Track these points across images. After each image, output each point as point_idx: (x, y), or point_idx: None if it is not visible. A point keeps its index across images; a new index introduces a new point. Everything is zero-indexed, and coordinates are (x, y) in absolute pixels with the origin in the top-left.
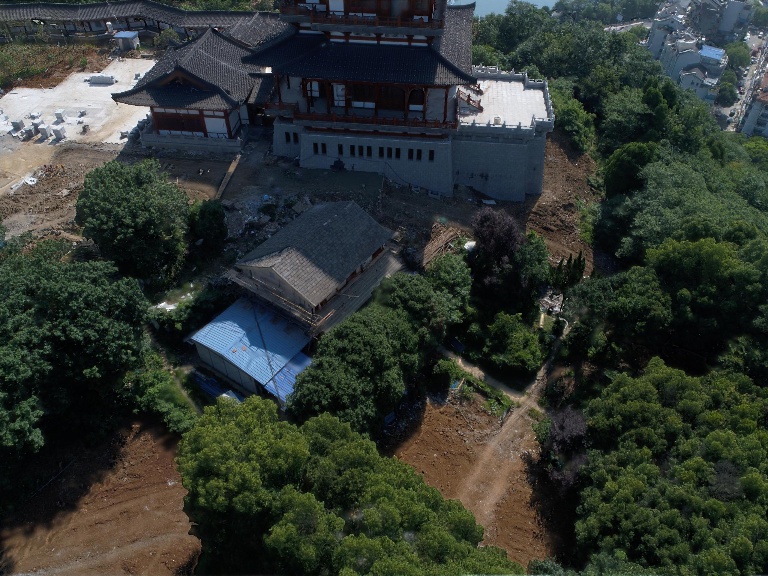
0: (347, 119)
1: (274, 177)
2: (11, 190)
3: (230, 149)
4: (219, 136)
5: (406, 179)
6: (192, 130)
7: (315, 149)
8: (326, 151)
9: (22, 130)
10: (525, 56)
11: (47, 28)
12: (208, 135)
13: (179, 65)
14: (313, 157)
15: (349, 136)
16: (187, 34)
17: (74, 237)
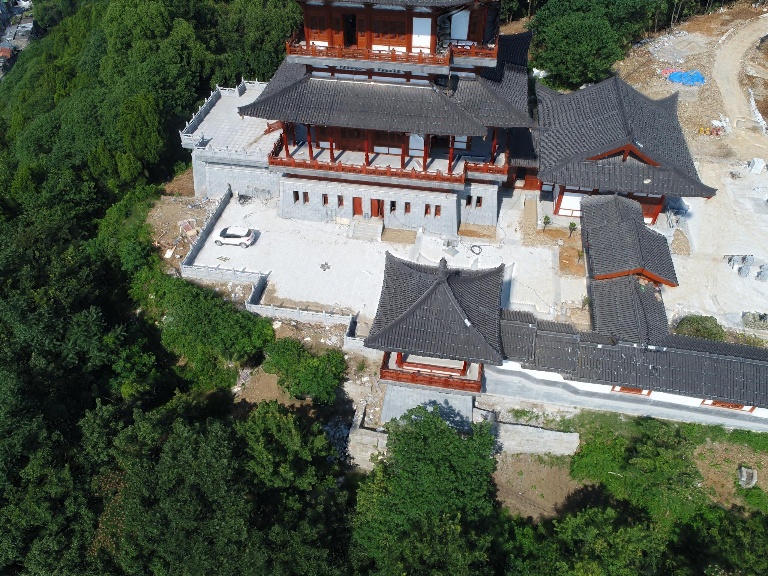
0: None
1: None
2: None
3: None
4: None
5: None
6: None
7: None
8: None
9: None
10: (100, 316)
11: None
12: None
13: (615, 76)
14: None
15: None
16: None
17: None
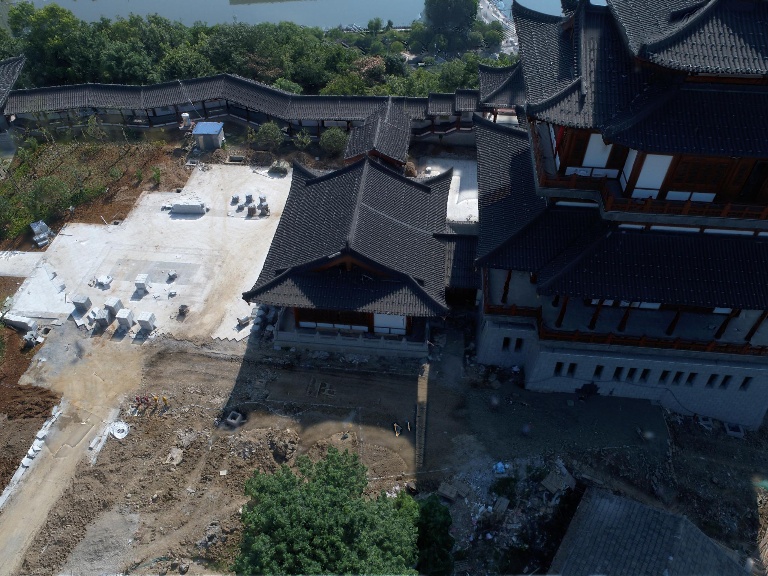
0: (630, 341)
1: (494, 414)
2: (90, 452)
3: (411, 354)
4: (391, 331)
5: (692, 408)
6: (351, 323)
7: (556, 368)
8: (574, 372)
9: (89, 314)
10: None
11: (97, 116)
12: (374, 329)
13: (350, 247)
14: (551, 378)
15: (619, 356)
16: (289, 125)
17: (211, 575)
